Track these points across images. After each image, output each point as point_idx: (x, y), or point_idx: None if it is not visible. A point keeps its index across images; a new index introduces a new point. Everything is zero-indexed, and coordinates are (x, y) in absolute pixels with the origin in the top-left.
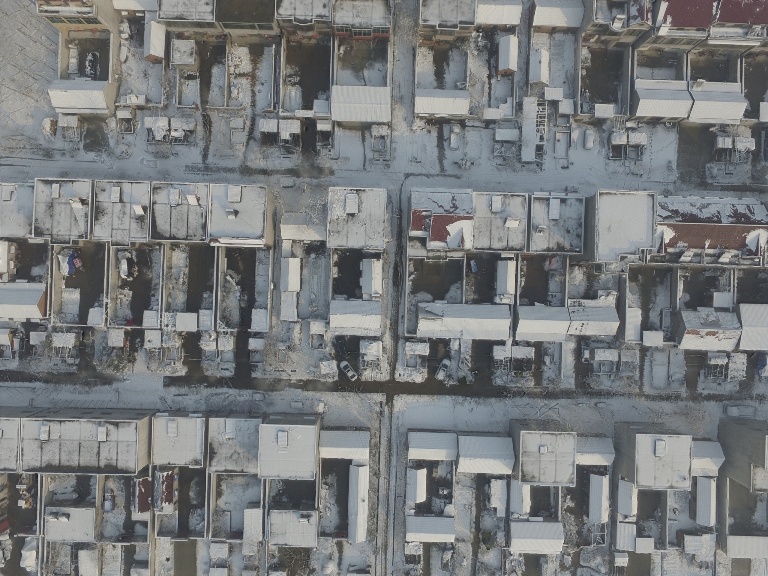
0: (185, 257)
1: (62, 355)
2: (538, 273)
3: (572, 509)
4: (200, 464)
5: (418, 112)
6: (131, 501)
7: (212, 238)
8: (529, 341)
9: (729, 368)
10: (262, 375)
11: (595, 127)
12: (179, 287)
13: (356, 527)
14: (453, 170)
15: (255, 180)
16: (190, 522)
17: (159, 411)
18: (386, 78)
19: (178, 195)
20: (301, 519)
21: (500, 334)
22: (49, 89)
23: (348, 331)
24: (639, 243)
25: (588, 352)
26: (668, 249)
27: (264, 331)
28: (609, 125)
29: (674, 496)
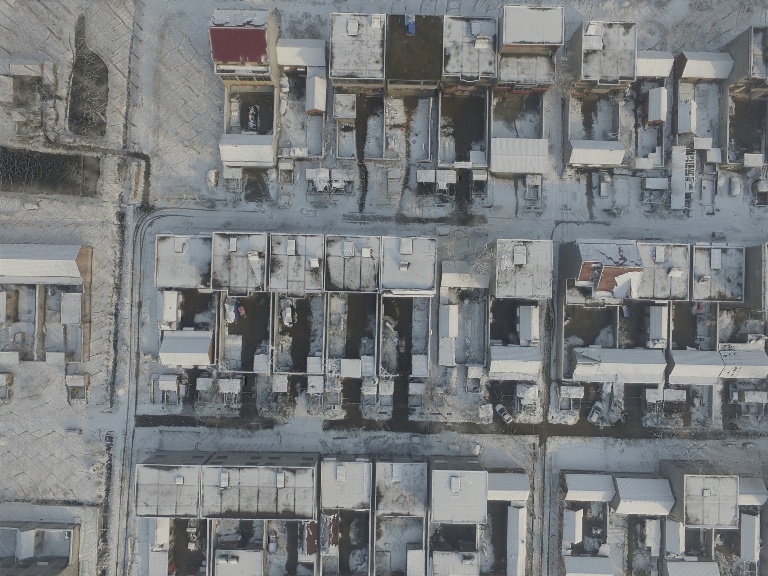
0: (344, 304)
1: (228, 401)
2: (686, 317)
3: (721, 547)
4: (367, 507)
5: (572, 162)
6: (298, 543)
7: (386, 289)
8: (679, 384)
9: None
10: (419, 418)
11: (739, 174)
12: (338, 333)
13: (517, 567)
14: (602, 217)
15: (411, 228)
16: (351, 562)
17: (320, 454)
18: (540, 129)
19: (352, 248)
20: (466, 561)
21: (654, 378)
22: (220, 144)
23: (507, 376)
24: None
25: (737, 394)
26: None
27: (425, 376)
28: (753, 172)
29: None
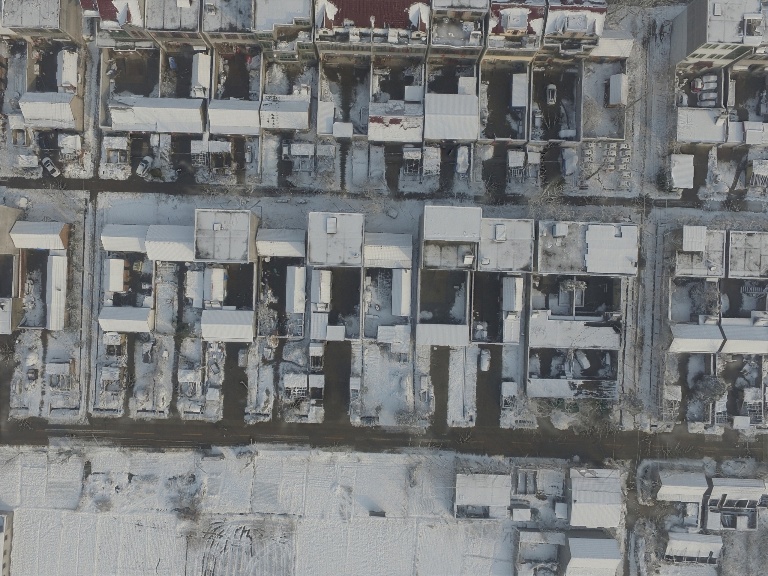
0: None
1: None
2: (241, 73)
3: (275, 305)
4: None
5: None
6: None
7: None
8: (229, 138)
9: (423, 162)
10: None
11: None
12: None
13: (50, 314)
14: None
15: None
16: None
17: None
18: None
19: None
20: None
21: (194, 126)
22: None
23: (43, 123)
24: (296, 14)
25: (287, 148)
26: (338, 29)
27: None
28: None
29: (376, 293)
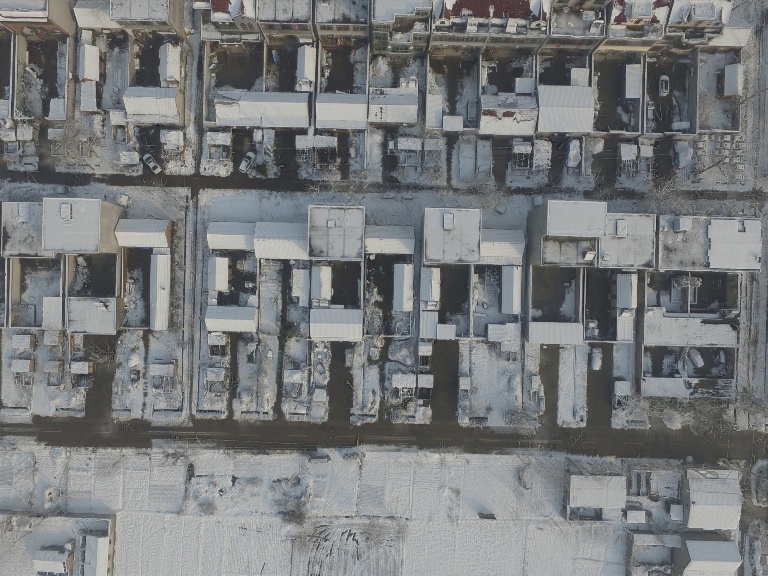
0: None
1: None
2: (344, 66)
3: (380, 304)
4: None
5: None
6: None
7: None
8: (334, 133)
9: (533, 156)
10: (66, 169)
11: None
12: None
13: (155, 314)
14: None
15: None
16: None
17: None
18: None
19: None
20: (96, 303)
21: (300, 121)
22: None
23: (146, 118)
24: (416, 4)
25: (393, 143)
26: (455, 19)
27: (62, 119)
28: None
29: (483, 290)
